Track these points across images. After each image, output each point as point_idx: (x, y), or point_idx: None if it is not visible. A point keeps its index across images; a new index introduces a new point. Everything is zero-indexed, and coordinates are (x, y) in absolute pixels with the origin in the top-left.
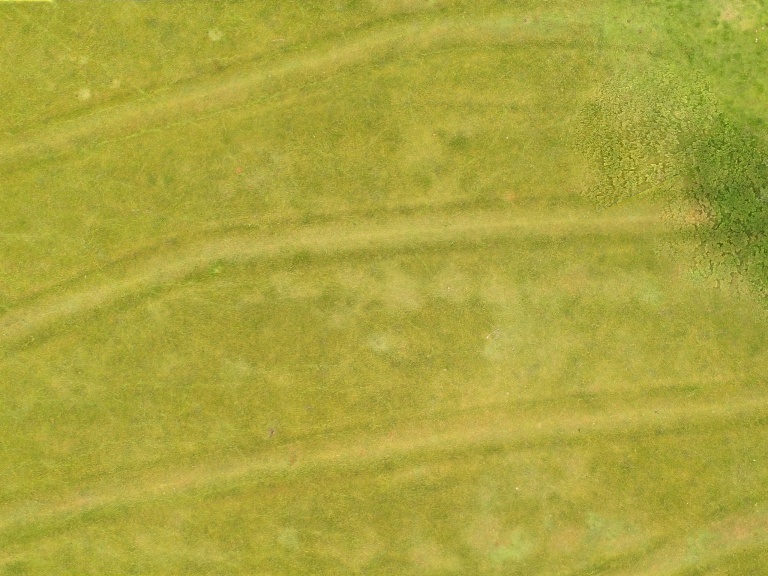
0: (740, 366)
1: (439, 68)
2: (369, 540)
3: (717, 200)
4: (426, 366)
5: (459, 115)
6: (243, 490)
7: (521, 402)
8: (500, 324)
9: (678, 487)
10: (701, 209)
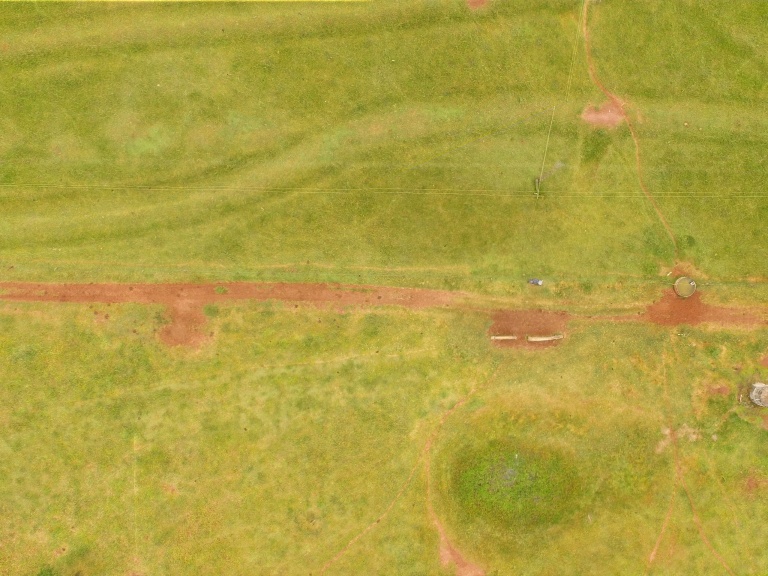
0: None
1: None
2: (8, 131)
3: None
4: None
5: None
6: None
7: (167, 3)
8: None
9: (318, 86)
10: None
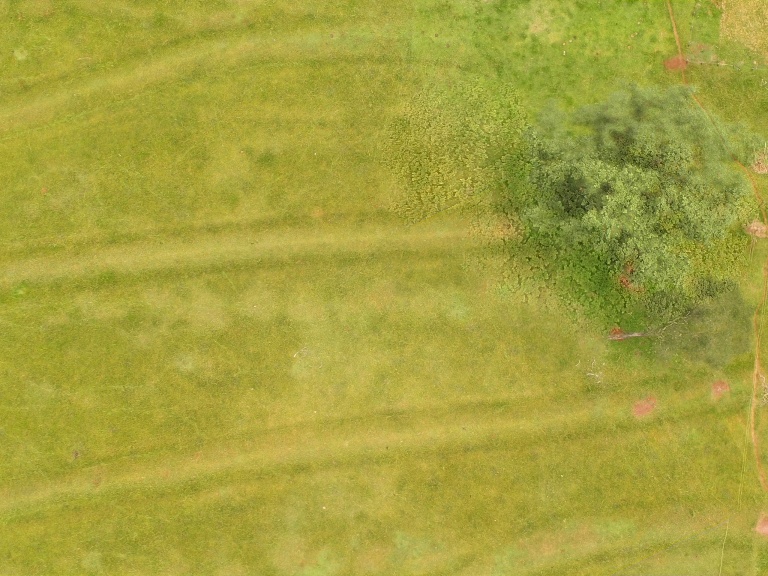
0: (549, 381)
1: (246, 85)
2: (174, 562)
3: (526, 214)
4: (232, 385)
5: (267, 132)
6: (48, 514)
7: (329, 420)
8: (307, 342)
9: (486, 504)
10: (509, 223)
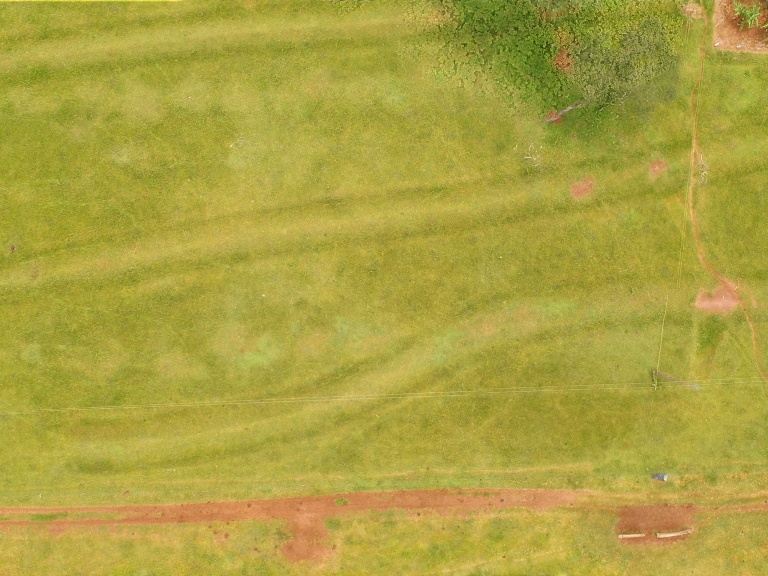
0: (486, 165)
1: None
2: (114, 352)
3: (461, 1)
4: (169, 177)
5: None
6: None
7: (266, 209)
8: (243, 132)
9: (426, 287)
10: (444, 10)
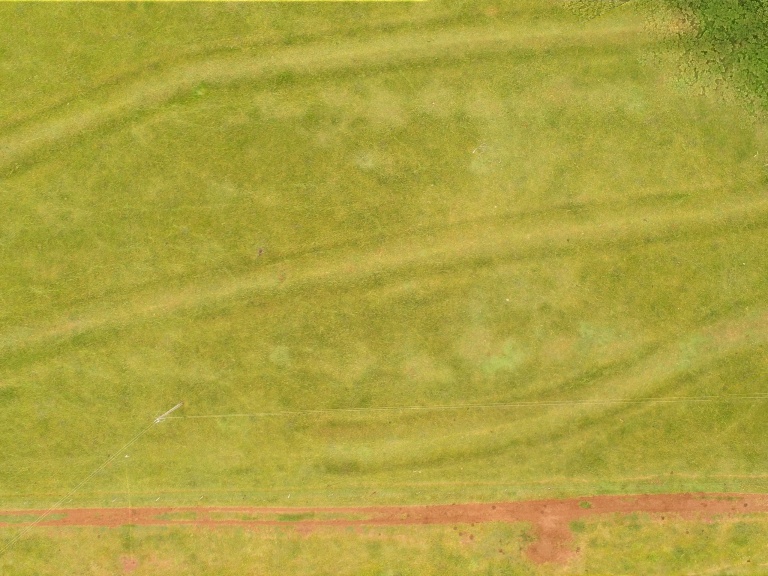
0: (727, 172)
1: None
2: (361, 355)
3: (700, 9)
4: (413, 182)
5: None
6: (233, 310)
7: (509, 215)
8: (486, 138)
9: (668, 293)
10: (684, 18)
